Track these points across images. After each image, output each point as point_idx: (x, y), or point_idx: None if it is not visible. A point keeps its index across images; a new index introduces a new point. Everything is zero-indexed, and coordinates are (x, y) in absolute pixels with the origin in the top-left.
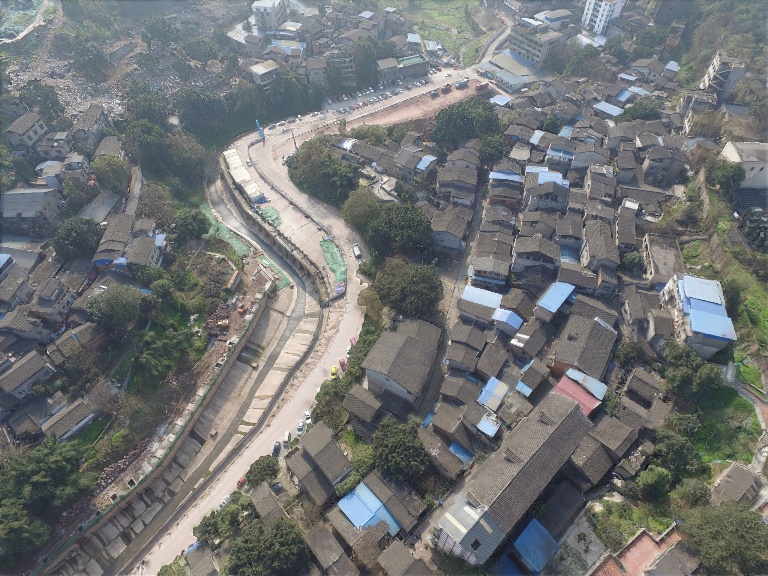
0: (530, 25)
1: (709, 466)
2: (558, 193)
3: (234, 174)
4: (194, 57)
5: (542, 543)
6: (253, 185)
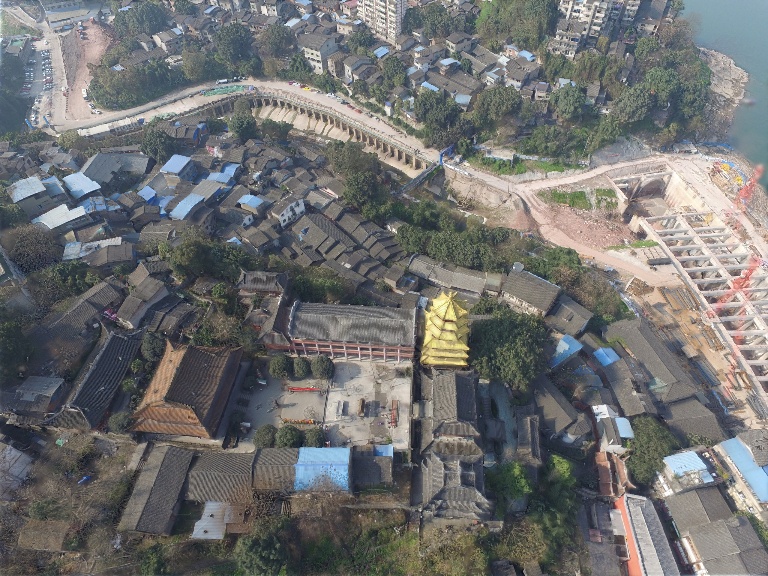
0: None
1: None
2: None
3: (96, 132)
4: None
5: None
6: (121, 121)
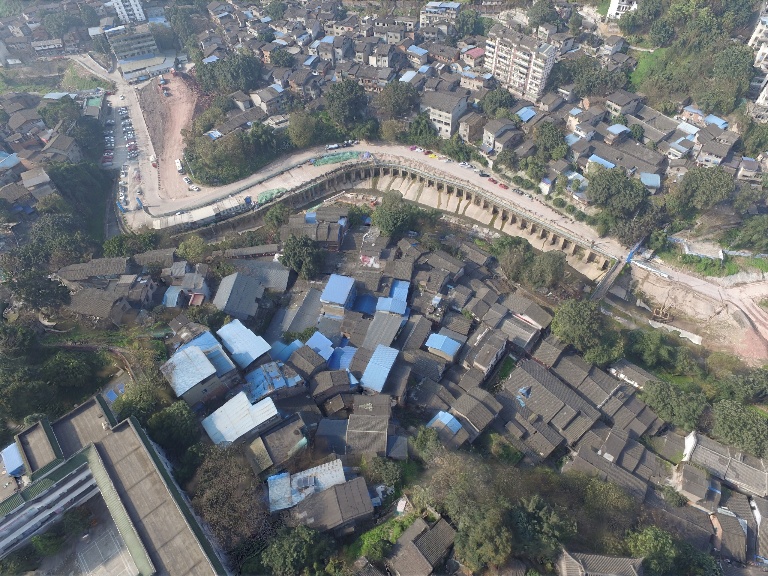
0: (119, 31)
1: None
2: (345, 37)
3: (200, 217)
4: None
5: None
6: (226, 202)
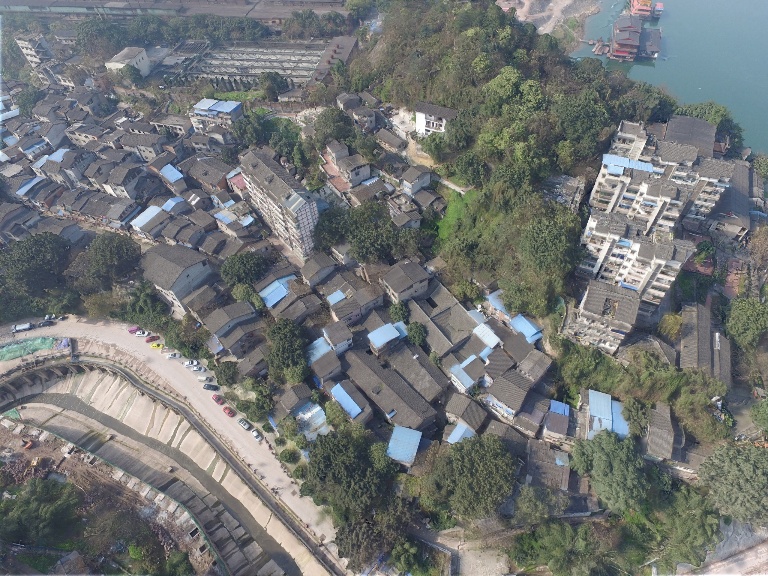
0: None
1: (299, 141)
2: (80, 152)
3: None
4: None
5: (317, 202)
6: None
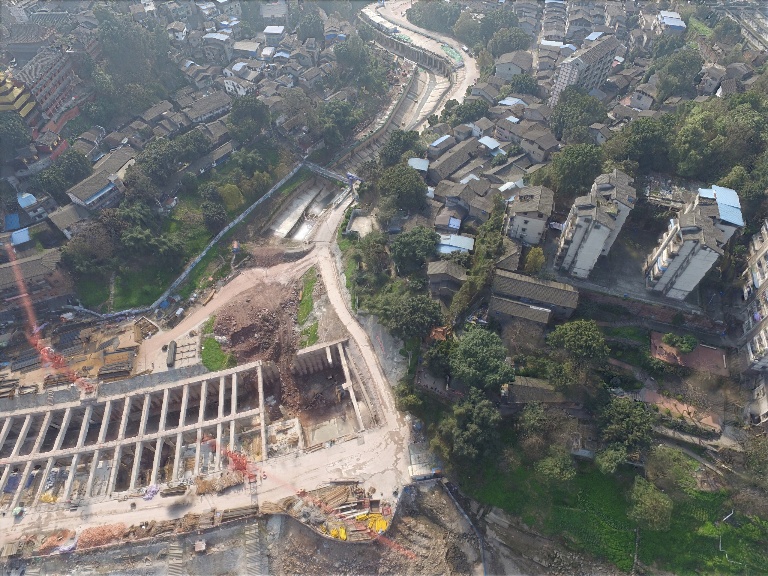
0: None
1: None
2: (589, 0)
3: (374, 19)
4: None
5: (600, 94)
6: (389, 23)
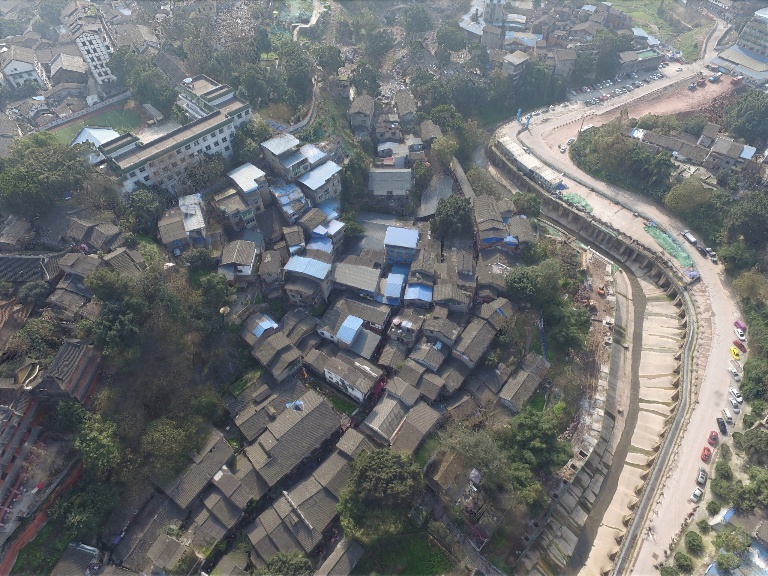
0: None
1: None
2: None
3: (522, 161)
4: (448, 46)
5: None
6: (548, 172)
